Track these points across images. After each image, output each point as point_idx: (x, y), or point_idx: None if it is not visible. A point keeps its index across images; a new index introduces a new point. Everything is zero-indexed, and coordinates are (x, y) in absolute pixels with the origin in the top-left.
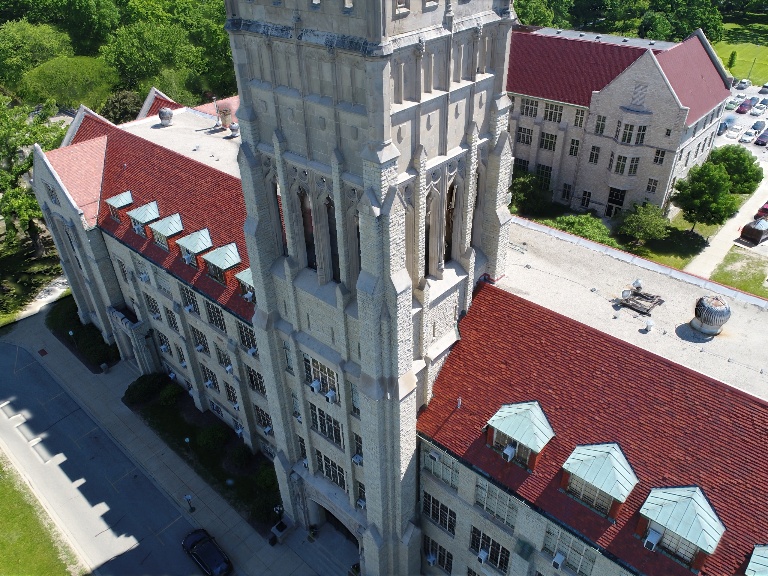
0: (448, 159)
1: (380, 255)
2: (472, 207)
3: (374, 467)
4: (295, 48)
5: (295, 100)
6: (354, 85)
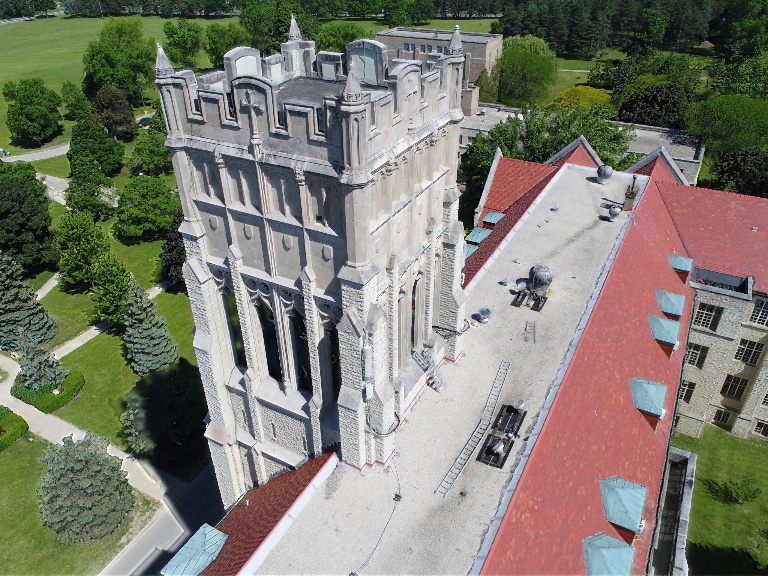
0: (270, 281)
1: None
2: (317, 356)
3: None
4: None
5: None
6: None
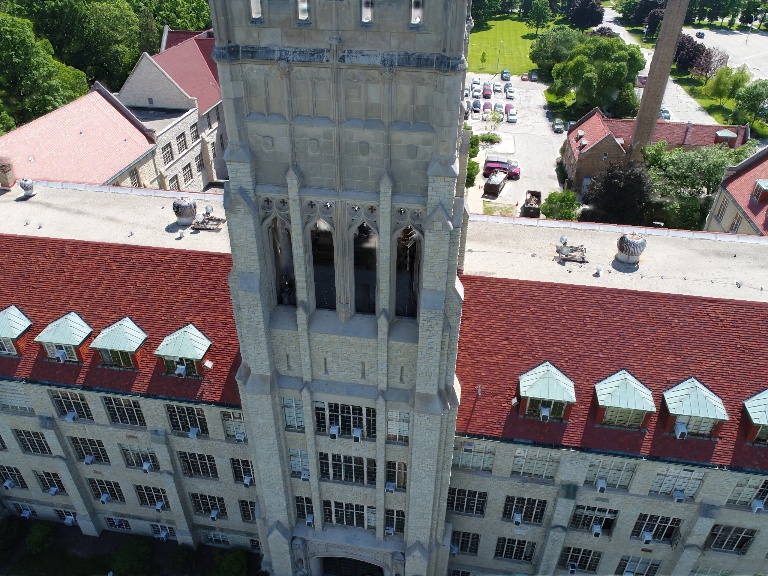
0: None
1: (447, 268)
2: None
3: (427, 484)
4: (329, 72)
5: (323, 129)
6: (415, 103)
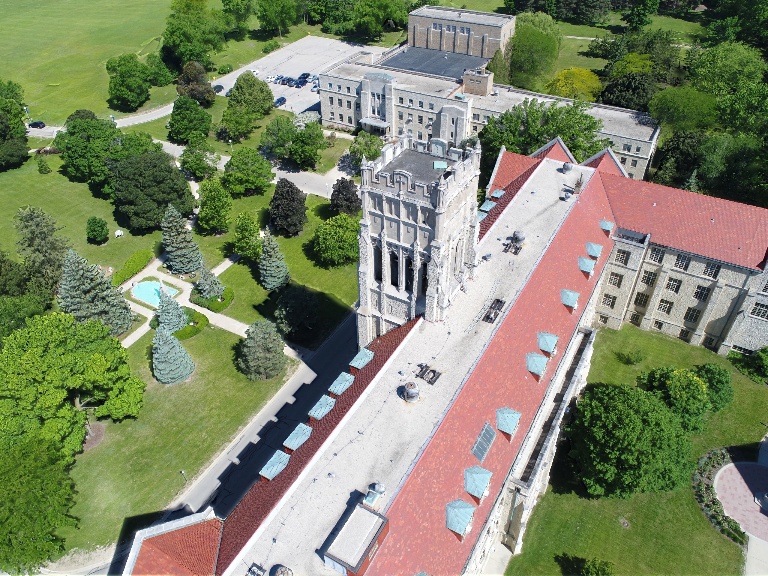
0: (399, 244)
1: None
2: (417, 275)
3: None
4: None
5: None
6: None
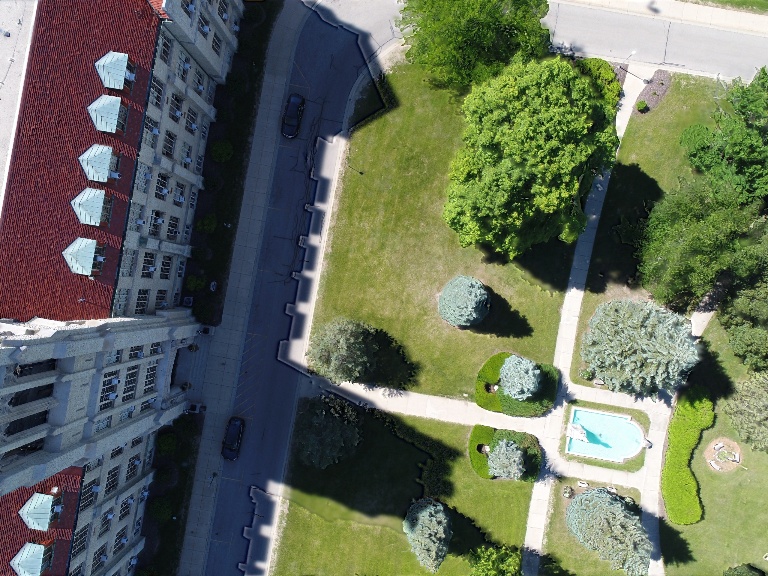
0: None
1: None
2: None
3: (144, 335)
4: None
5: None
6: None
